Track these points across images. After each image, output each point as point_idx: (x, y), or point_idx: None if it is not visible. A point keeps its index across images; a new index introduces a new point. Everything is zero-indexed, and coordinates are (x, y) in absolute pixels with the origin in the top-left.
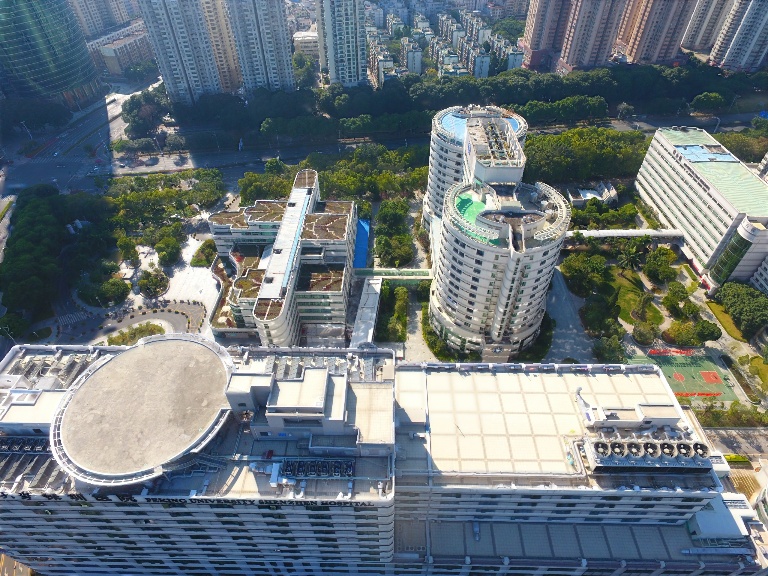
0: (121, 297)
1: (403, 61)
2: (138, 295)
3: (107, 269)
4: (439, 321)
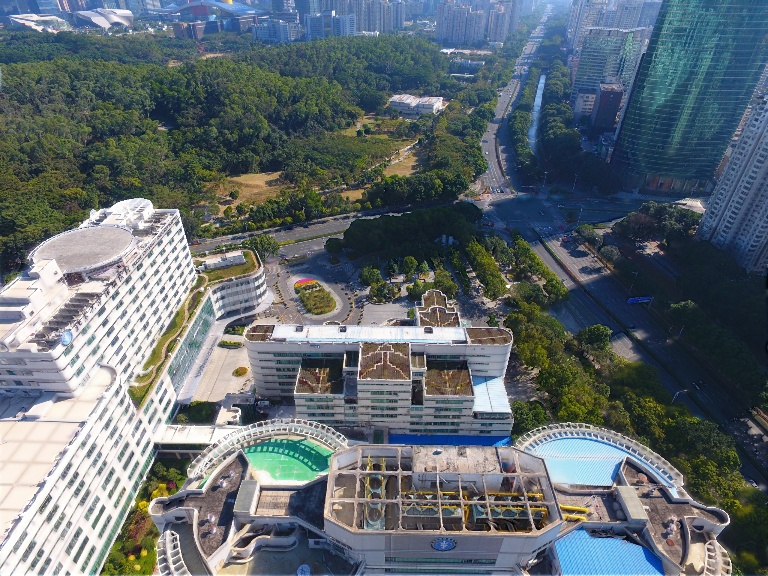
0: (367, 282)
1: None
2: None
3: (389, 265)
4: None
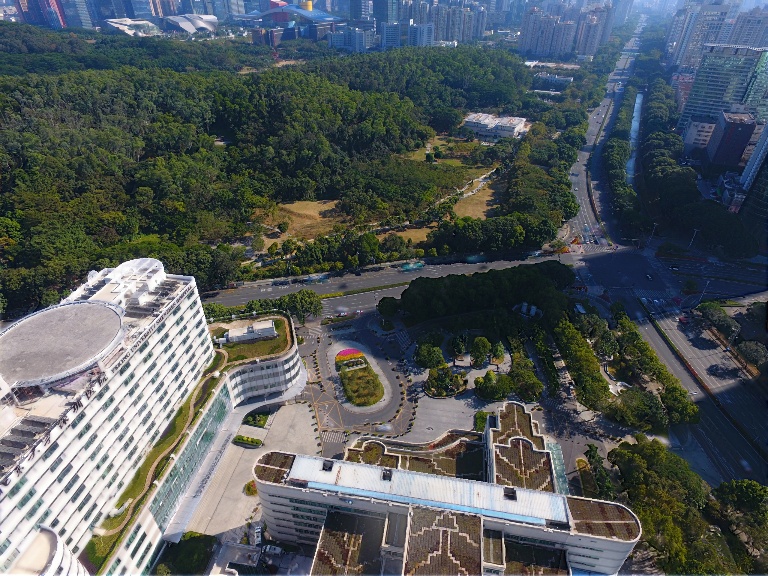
0: (424, 363)
1: None
2: None
3: (454, 342)
4: None
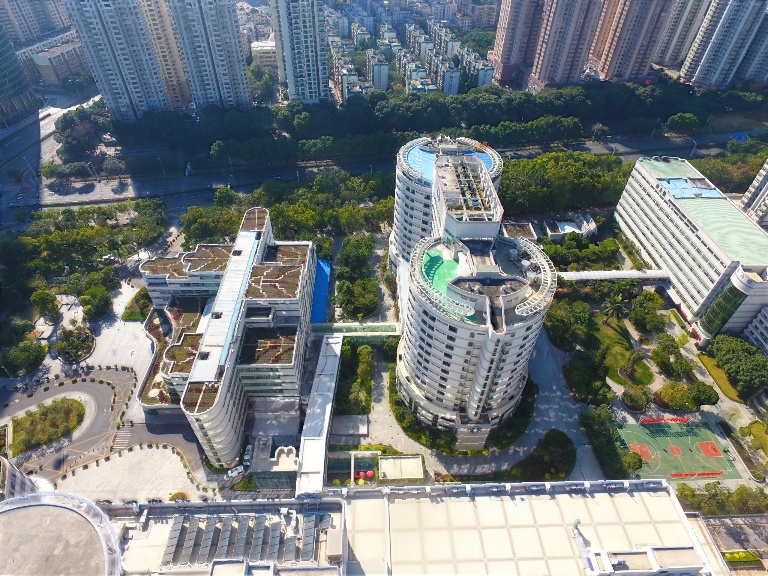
0: (34, 364)
1: (369, 74)
2: (56, 360)
3: (18, 329)
4: (407, 392)
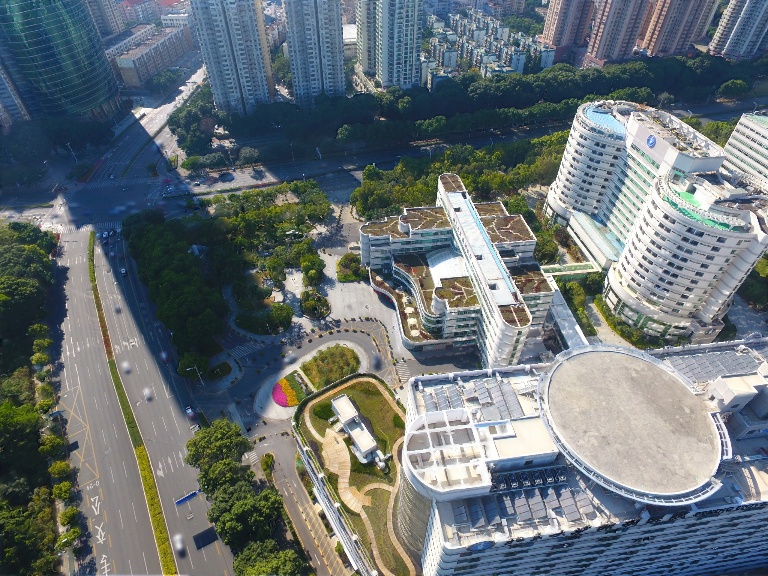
0: (287, 322)
1: None
2: (302, 318)
3: (263, 294)
4: (637, 311)
